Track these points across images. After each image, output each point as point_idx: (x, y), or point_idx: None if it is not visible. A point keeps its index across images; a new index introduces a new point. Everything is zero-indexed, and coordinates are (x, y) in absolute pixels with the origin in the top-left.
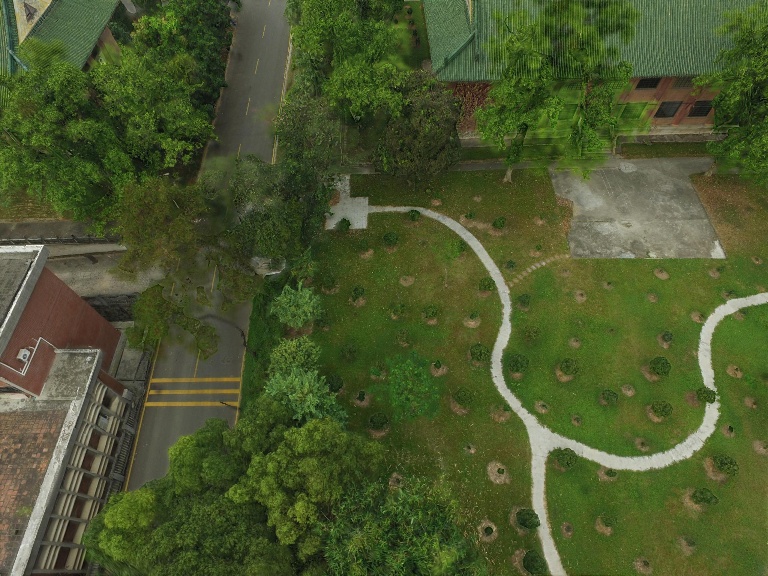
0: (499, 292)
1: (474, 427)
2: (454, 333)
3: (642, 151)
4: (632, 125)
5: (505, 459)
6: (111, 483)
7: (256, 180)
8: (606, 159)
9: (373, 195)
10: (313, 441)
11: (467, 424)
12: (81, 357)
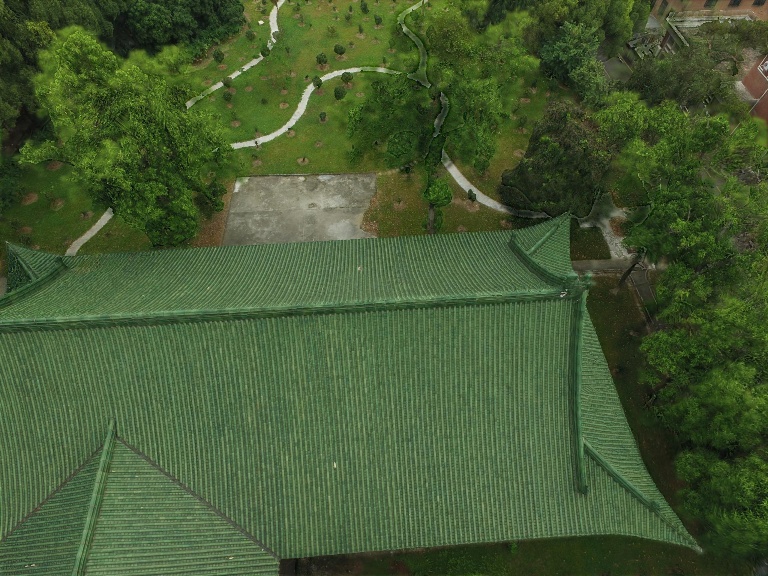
0: None
1: None
2: None
3: None
4: None
5: None
6: None
7: None
8: None
9: (576, 229)
10: None
11: None
12: None
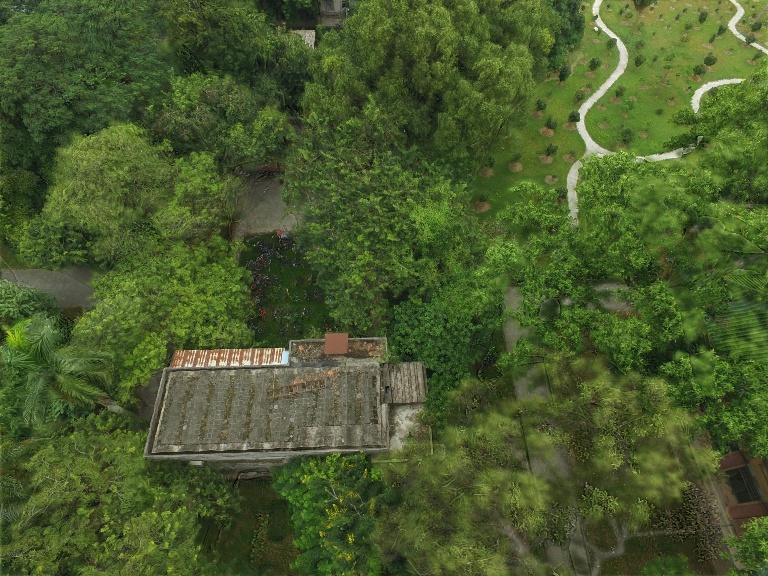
0: None
1: None
2: None
3: None
4: None
5: None
6: None
7: None
8: None
9: None
10: None
11: None
12: None
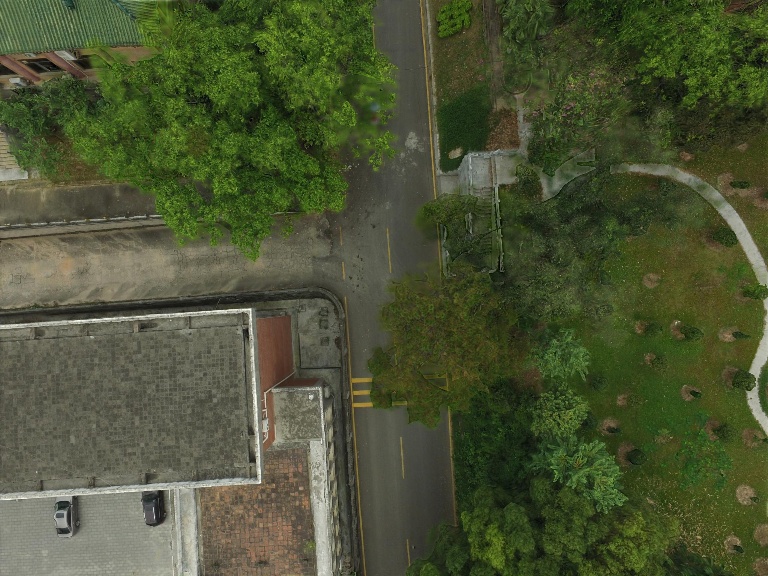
0: None
1: None
2: (708, 349)
3: None
4: None
5: (755, 483)
6: (352, 489)
7: (563, 255)
8: None
9: (601, 145)
10: (641, 554)
11: None
12: (301, 394)
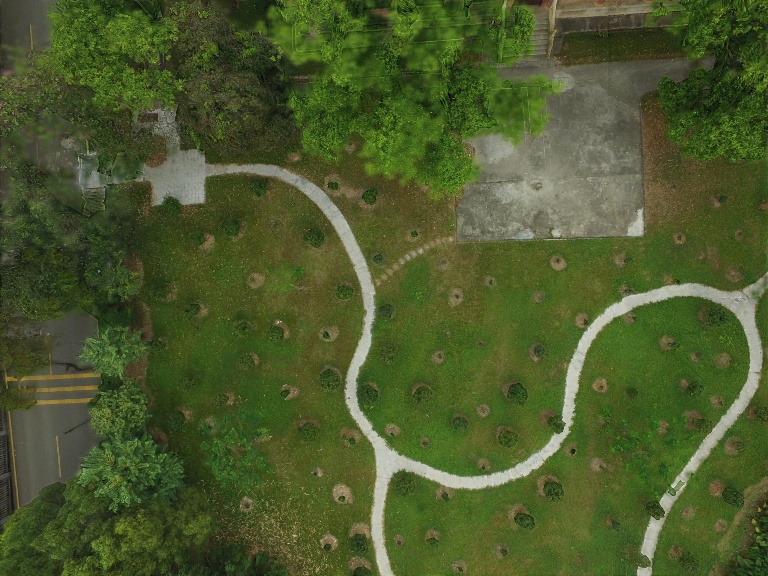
0: (363, 294)
1: (323, 452)
2: (308, 349)
3: (590, 50)
4: (585, 3)
5: (350, 482)
6: None
7: None
8: (536, 67)
9: None
10: (120, 551)
11: (316, 449)
12: None
